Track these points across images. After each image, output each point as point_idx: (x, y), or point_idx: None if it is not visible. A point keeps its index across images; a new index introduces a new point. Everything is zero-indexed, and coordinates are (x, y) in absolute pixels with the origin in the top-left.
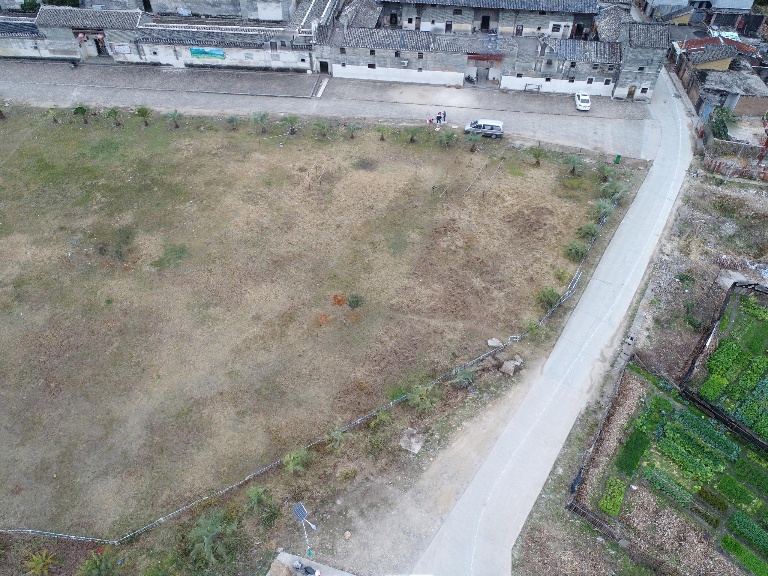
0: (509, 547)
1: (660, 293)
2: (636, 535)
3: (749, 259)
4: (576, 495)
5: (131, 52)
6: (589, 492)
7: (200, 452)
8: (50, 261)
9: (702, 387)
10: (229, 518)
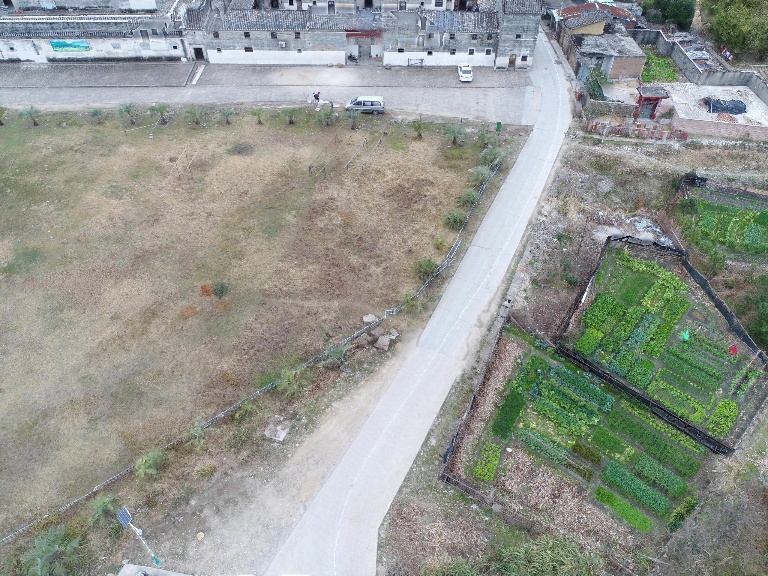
0: (375, 527)
1: (537, 254)
2: (511, 498)
3: (625, 214)
4: (450, 465)
5: None
6: (463, 460)
7: (44, 467)
8: None
9: (578, 342)
10: (71, 535)
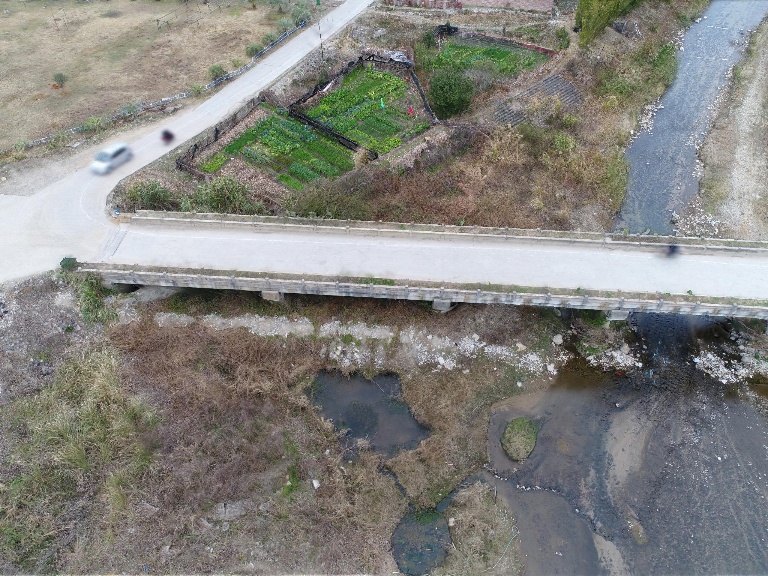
0: (119, 179)
1: (305, 67)
2: None
3: (387, 49)
4: None
5: None
6: (197, 161)
7: None
8: None
9: (309, 111)
10: None
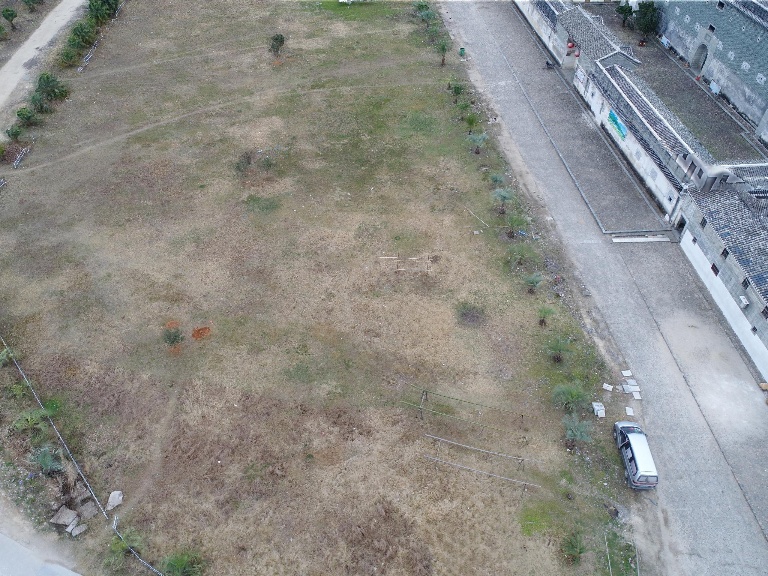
0: None
1: None
2: None
3: None
4: None
5: (583, 82)
6: None
7: (25, 278)
8: (251, 145)
9: None
10: None
